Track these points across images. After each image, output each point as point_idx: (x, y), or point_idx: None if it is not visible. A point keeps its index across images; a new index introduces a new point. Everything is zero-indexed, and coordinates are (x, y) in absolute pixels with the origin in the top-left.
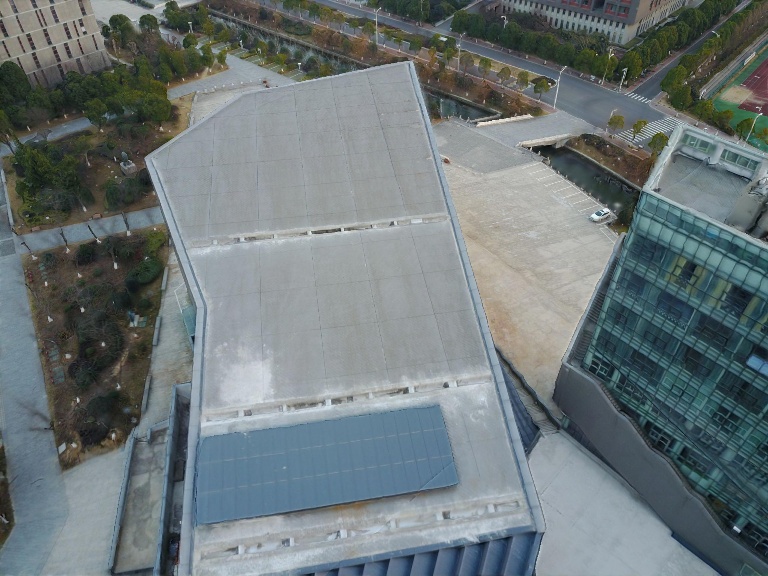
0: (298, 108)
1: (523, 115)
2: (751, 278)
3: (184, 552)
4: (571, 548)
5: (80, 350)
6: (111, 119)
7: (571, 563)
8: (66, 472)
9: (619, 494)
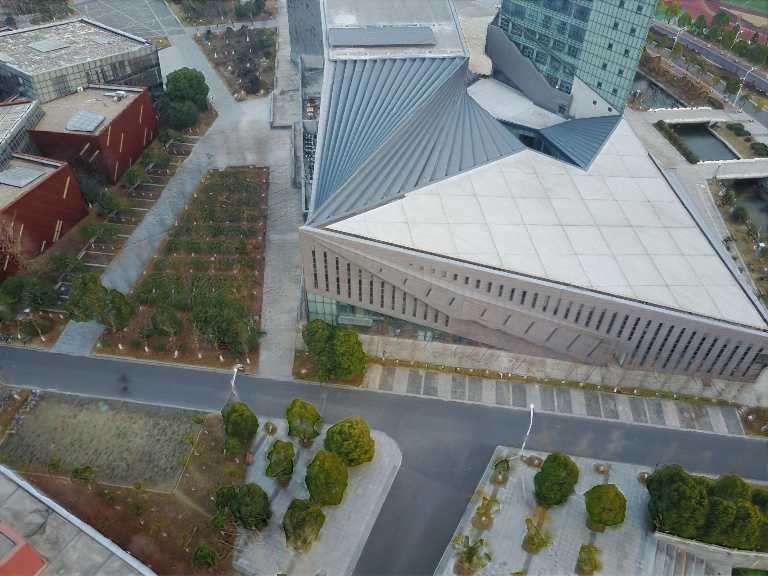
0: None
1: None
2: None
3: (326, 52)
4: (486, 104)
5: (236, 66)
6: None
7: (485, 107)
8: (240, 103)
9: (513, 94)
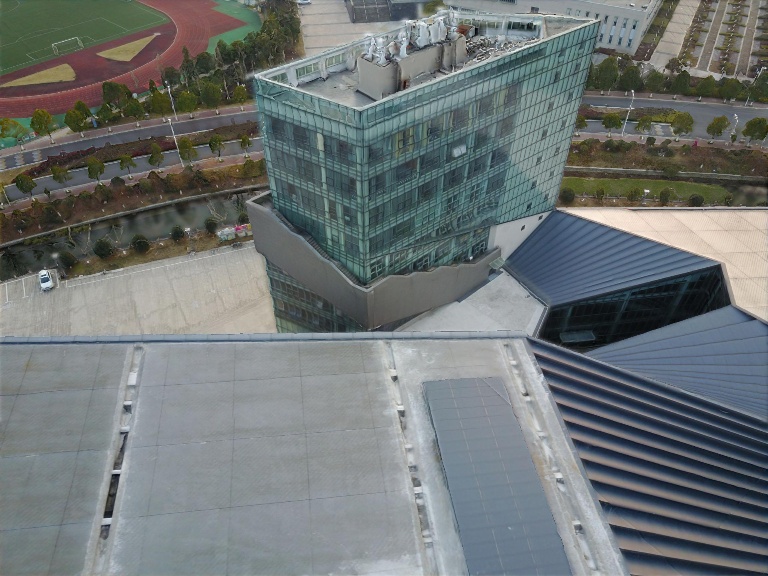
0: None
1: None
2: None
3: None
4: None
5: None
6: None
7: None
8: None
9: (428, 323)
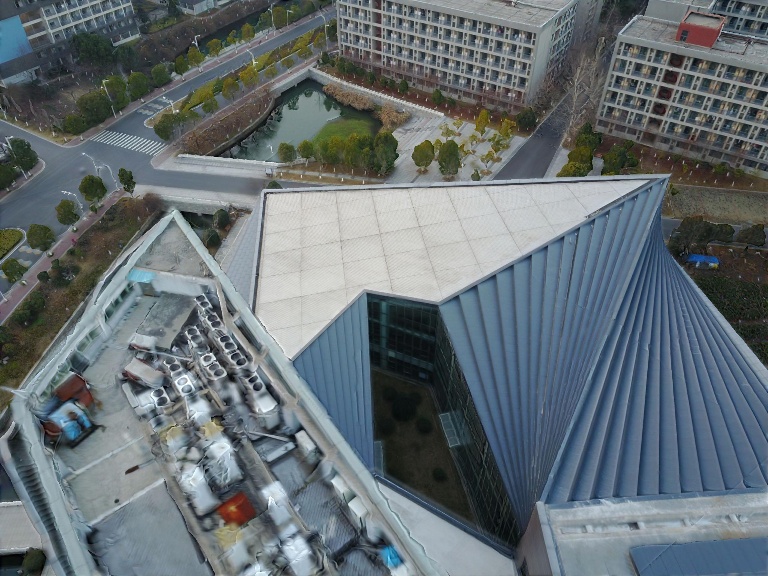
0: None
1: None
2: None
3: None
4: None
5: None
6: None
7: (465, 574)
8: None
9: None
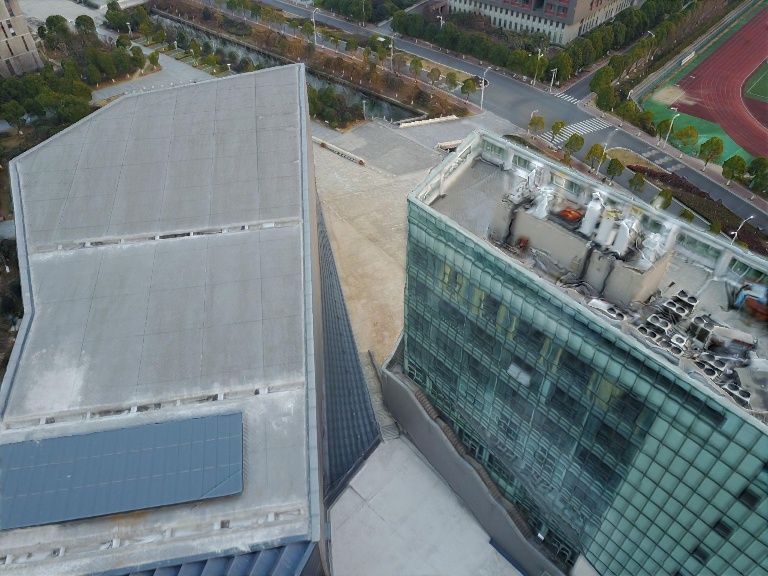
0: (177, 111)
1: (447, 116)
2: (494, 286)
3: None
4: (386, 555)
5: None
6: (32, 121)
7: (383, 570)
8: None
9: (446, 500)
